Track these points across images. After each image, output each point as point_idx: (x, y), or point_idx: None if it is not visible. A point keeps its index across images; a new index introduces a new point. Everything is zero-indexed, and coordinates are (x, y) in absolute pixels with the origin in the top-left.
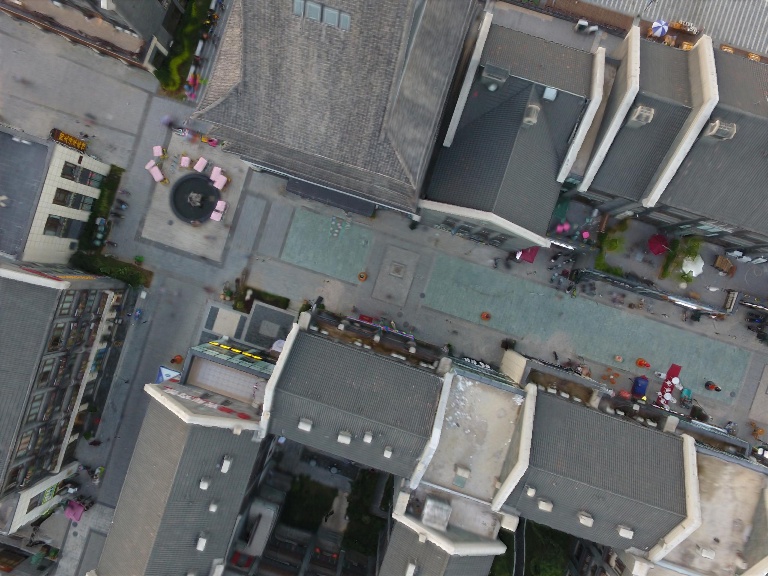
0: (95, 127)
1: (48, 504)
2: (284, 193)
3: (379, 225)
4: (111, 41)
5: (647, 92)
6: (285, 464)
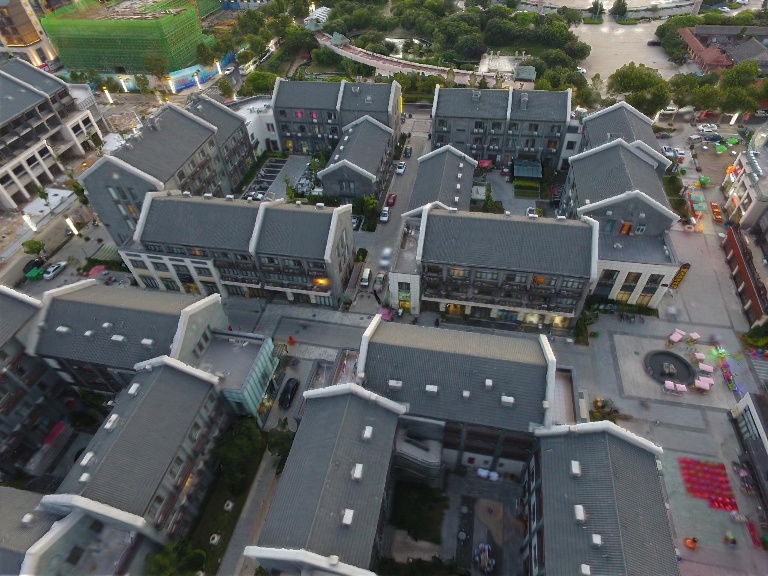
0: (679, 296)
1: (395, 297)
2: (725, 444)
3: (760, 557)
4: (766, 294)
5: None
6: (454, 480)
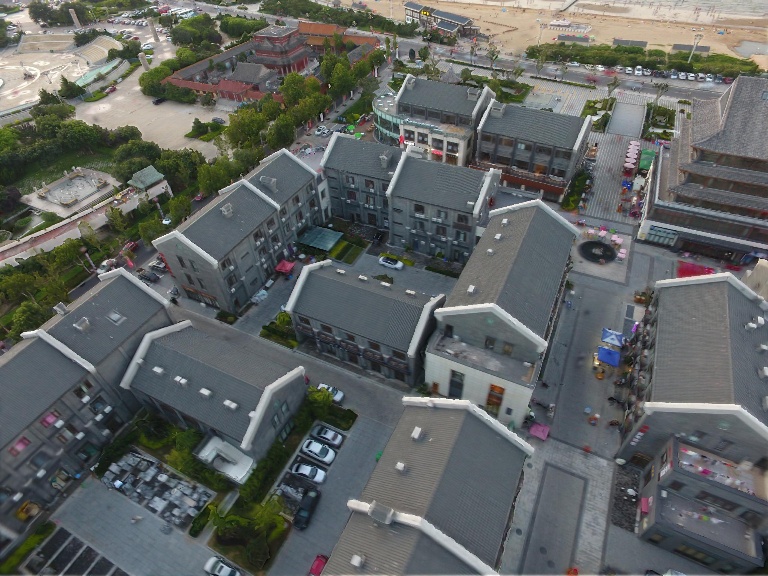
0: None
1: None
2: (662, 253)
3: (743, 273)
4: None
5: None
6: None
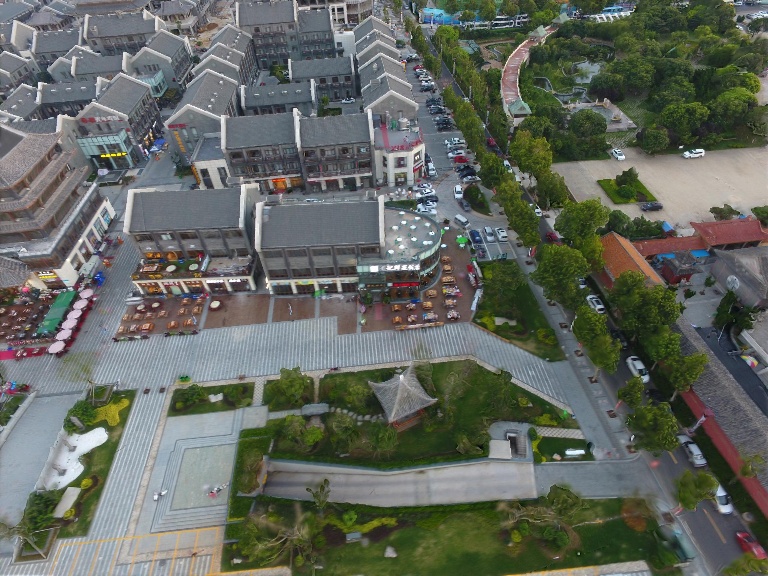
0: None
1: None
2: None
3: None
4: None
5: None
6: None
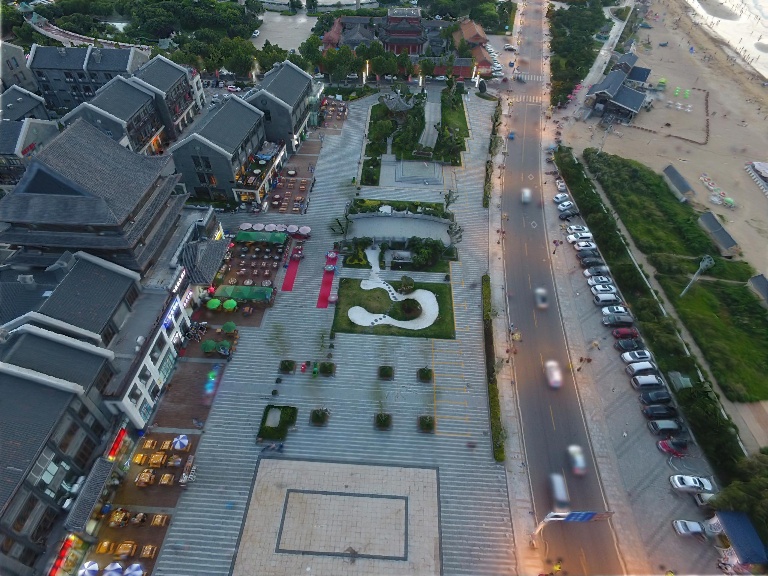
0: None
1: None
2: None
3: None
4: None
5: (23, 338)
6: None
